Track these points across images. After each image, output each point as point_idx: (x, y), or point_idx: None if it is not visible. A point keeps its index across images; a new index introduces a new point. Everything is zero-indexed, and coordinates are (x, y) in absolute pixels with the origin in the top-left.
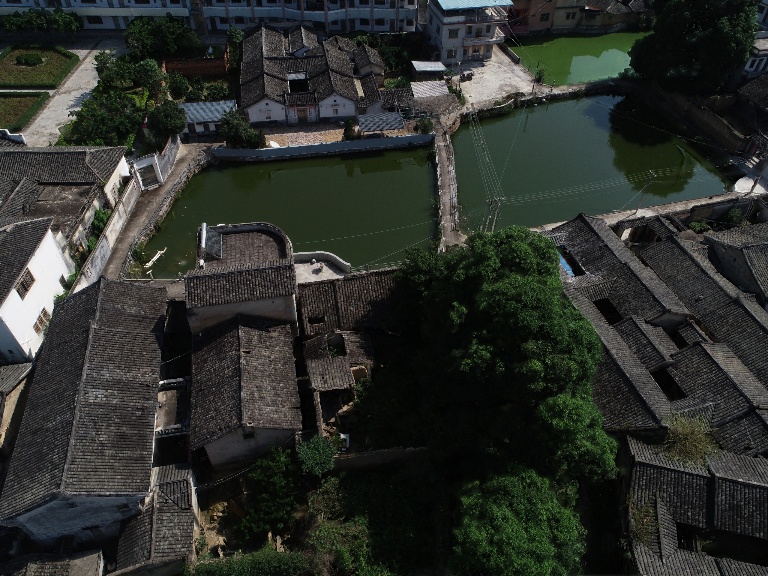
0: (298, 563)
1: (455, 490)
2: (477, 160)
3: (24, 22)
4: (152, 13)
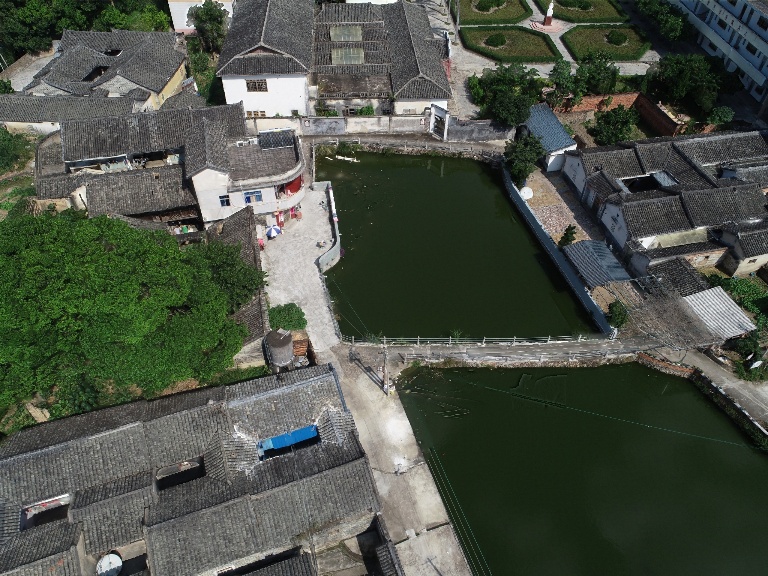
0: None
1: None
2: None
3: (655, 11)
4: (741, 63)
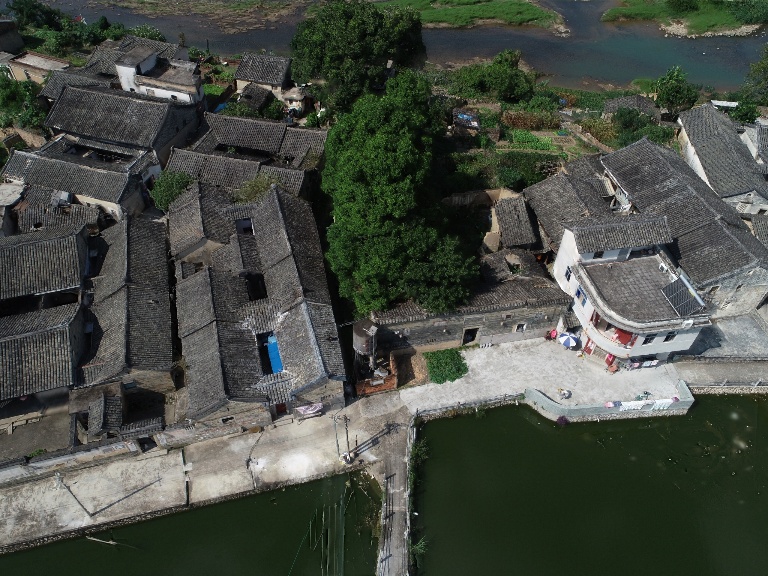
0: (504, 154)
1: None
2: None
3: None
4: None
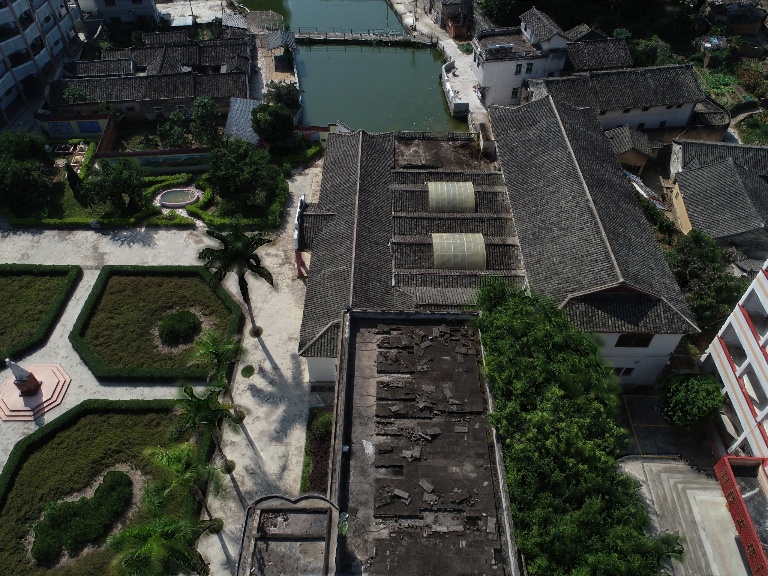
0: None
1: (630, 0)
2: (358, 4)
3: None
4: None
